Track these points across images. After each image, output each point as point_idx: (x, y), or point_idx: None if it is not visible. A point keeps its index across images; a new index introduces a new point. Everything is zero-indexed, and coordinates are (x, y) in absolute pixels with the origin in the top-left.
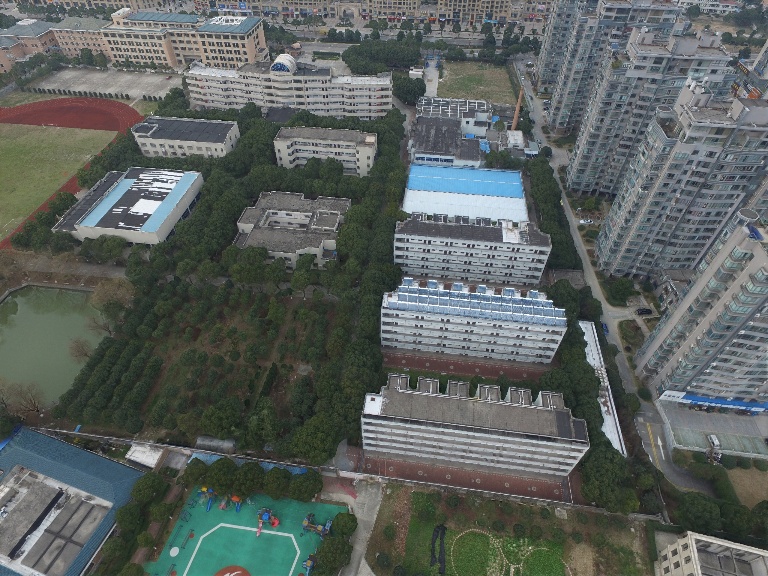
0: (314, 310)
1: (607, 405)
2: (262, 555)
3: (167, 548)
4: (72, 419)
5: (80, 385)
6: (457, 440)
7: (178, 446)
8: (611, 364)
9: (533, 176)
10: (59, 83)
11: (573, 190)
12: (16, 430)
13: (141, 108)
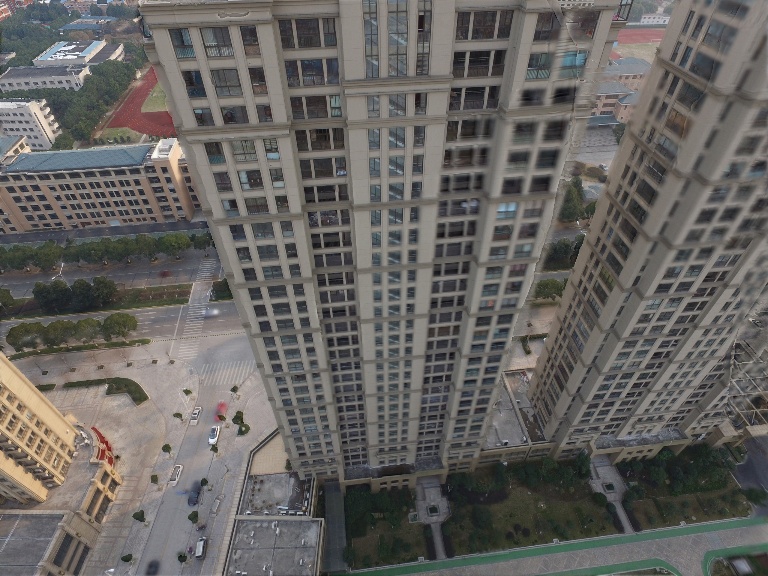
0: None
1: None
2: None
3: None
4: (96, 38)
5: None
6: None
7: None
8: None
9: None
10: None
11: None
12: None
13: (130, 133)
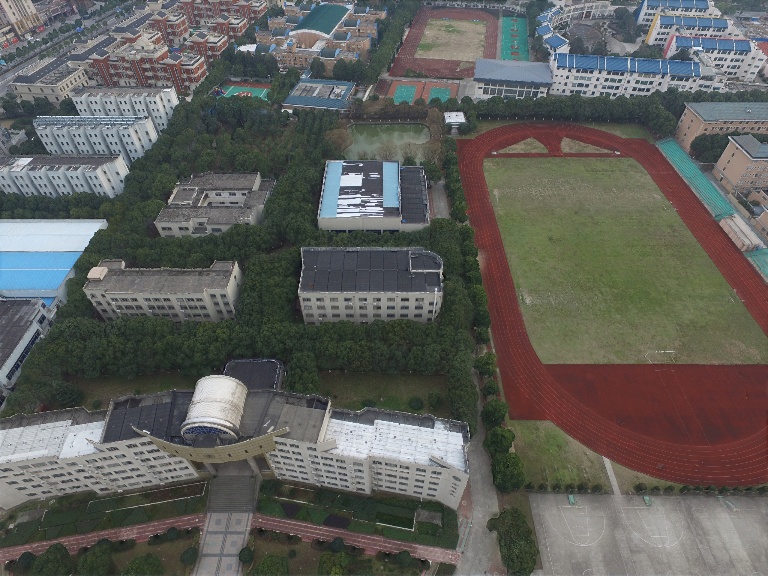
0: (208, 169)
1: None
2: None
3: None
4: None
5: None
6: None
7: None
8: None
9: None
10: None
11: None
12: None
13: (573, 450)
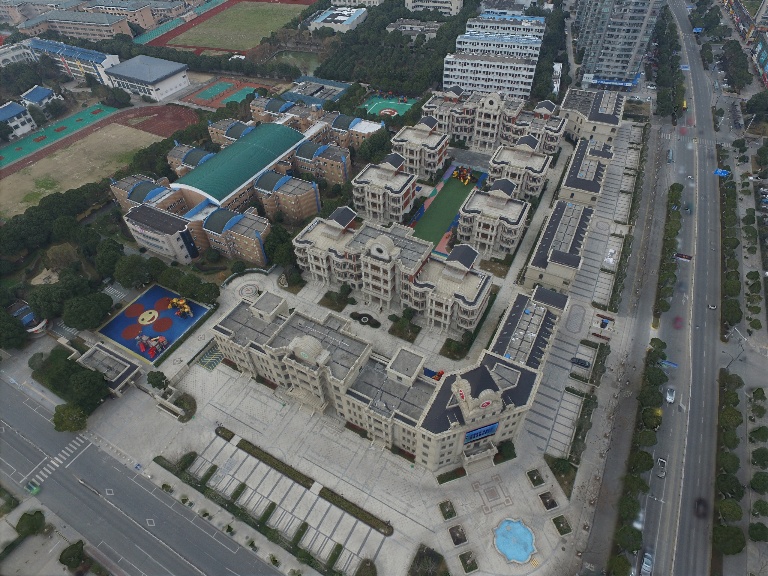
0: None
1: (556, 82)
2: (400, 107)
3: (364, 104)
4: None
5: (323, 67)
6: None
7: None
8: (564, 72)
9: (550, 15)
10: None
11: (576, 29)
12: None
13: None
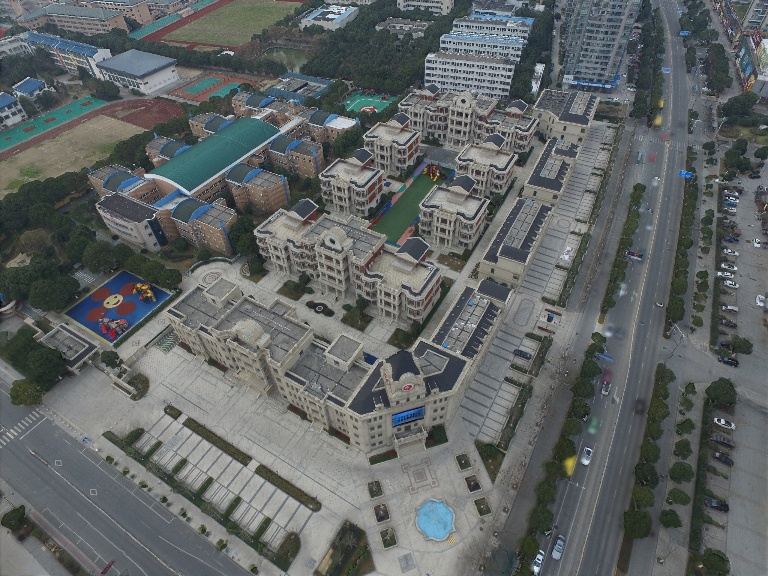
0: None
1: (537, 82)
2: None
3: (346, 101)
4: None
5: None
6: (463, 70)
7: (349, 81)
8: None
9: None
10: None
11: (565, 30)
12: (287, 72)
13: None
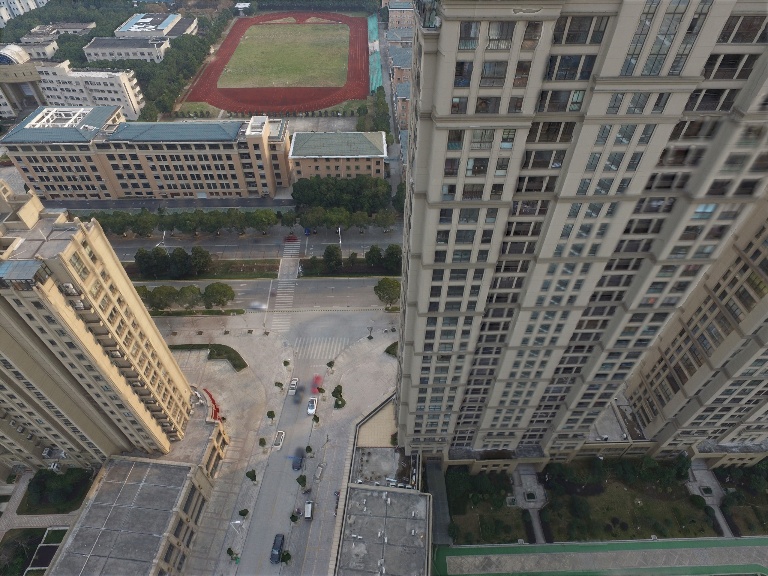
0: None
1: None
2: None
3: None
4: (167, 11)
5: None
6: None
7: None
8: None
9: None
10: (334, 129)
11: None
12: None
13: (209, 108)
